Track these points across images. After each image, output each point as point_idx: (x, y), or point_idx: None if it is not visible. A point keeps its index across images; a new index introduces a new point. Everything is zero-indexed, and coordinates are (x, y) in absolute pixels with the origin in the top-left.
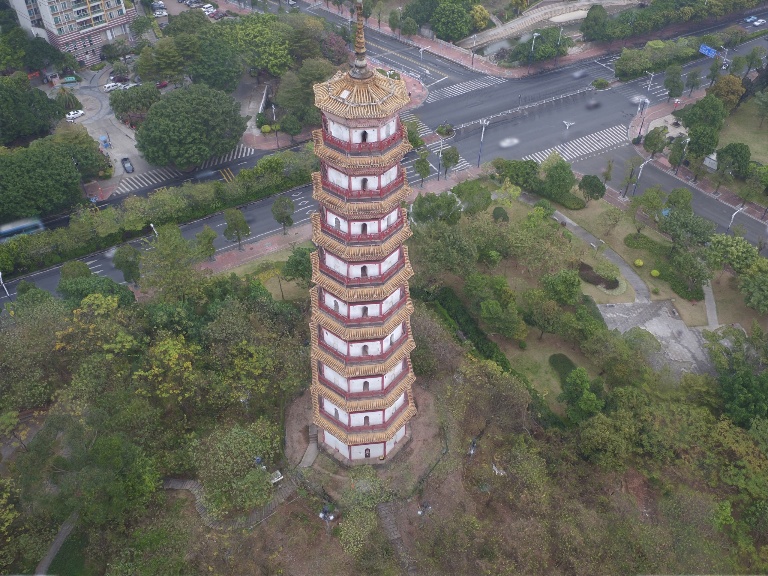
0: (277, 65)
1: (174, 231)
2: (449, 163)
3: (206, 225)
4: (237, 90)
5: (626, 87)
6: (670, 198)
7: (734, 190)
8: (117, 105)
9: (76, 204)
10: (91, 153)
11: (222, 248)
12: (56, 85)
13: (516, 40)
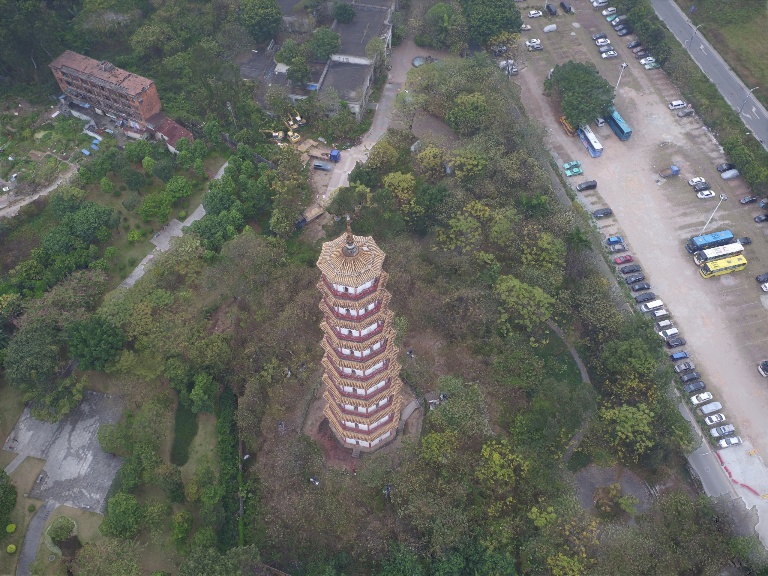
0: None
1: None
2: None
3: None
4: None
5: None
6: None
7: None
8: None
9: None
10: None
11: None
12: None
13: None
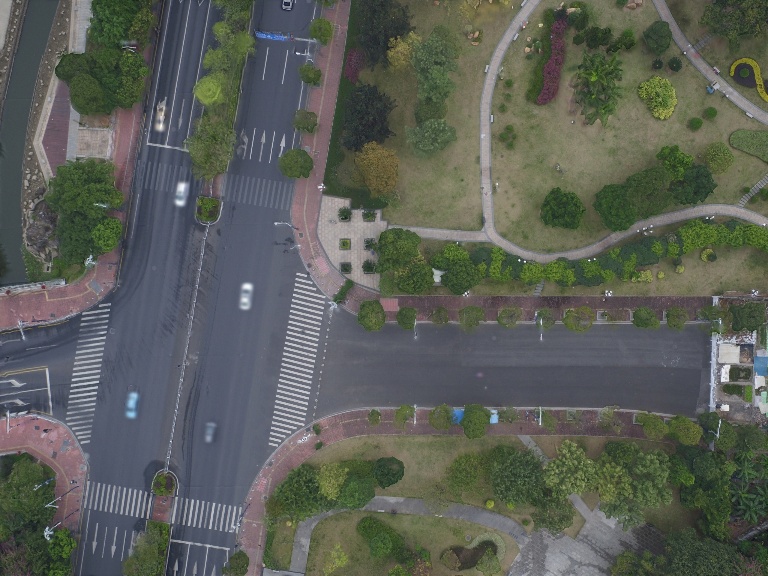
0: None
1: None
2: (244, 571)
3: None
4: None
5: (235, 181)
6: None
7: (478, 291)
8: None
9: None
10: None
11: None
12: None
13: (1, 157)
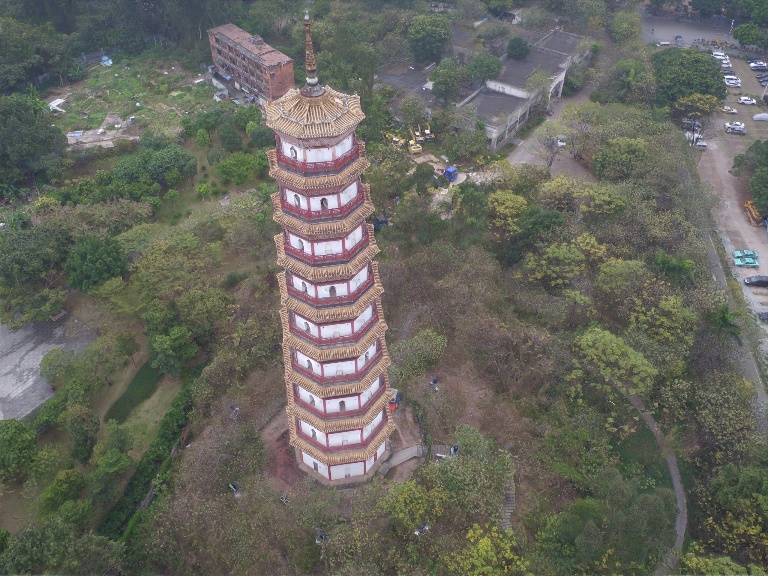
0: None
1: None
2: None
3: None
4: None
5: None
6: None
7: None
8: None
9: None
10: None
11: None
12: None
13: None
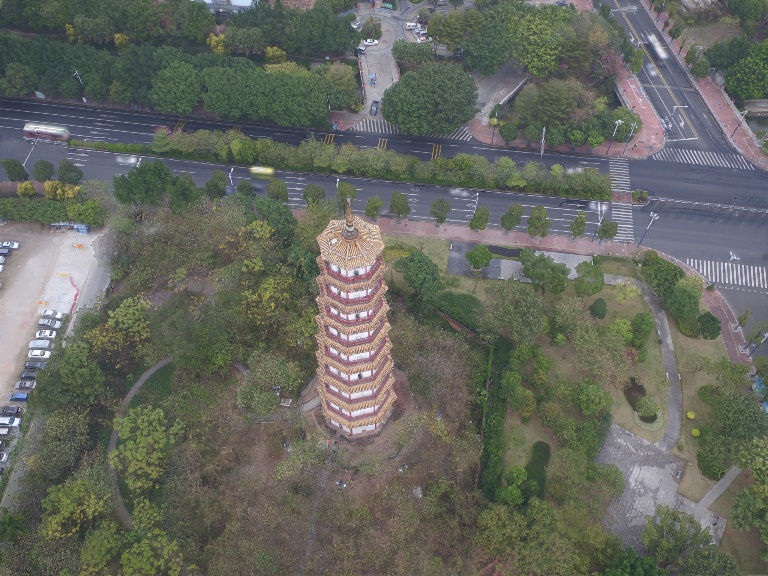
0: (538, 67)
1: (334, 200)
2: (603, 234)
3: (378, 195)
4: (502, 70)
5: None
6: (765, 379)
7: None
8: (396, 52)
9: (311, 133)
10: (344, 95)
11: (387, 213)
12: (376, 7)
13: None
